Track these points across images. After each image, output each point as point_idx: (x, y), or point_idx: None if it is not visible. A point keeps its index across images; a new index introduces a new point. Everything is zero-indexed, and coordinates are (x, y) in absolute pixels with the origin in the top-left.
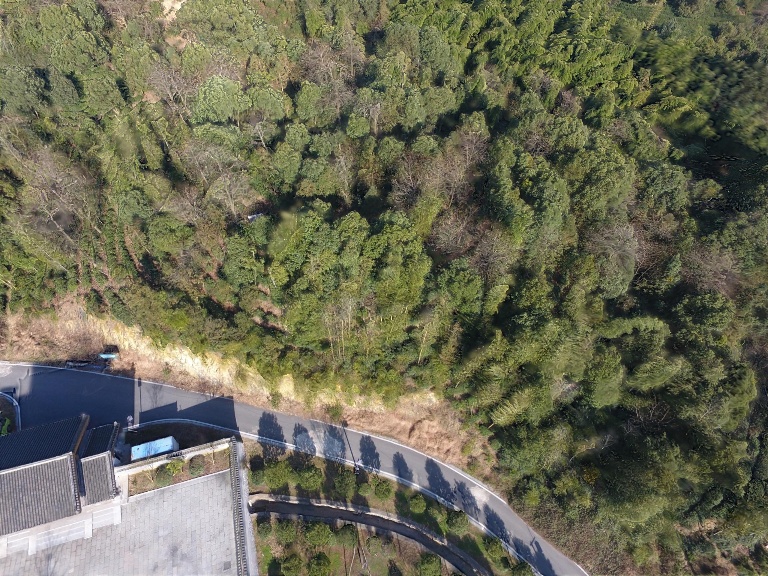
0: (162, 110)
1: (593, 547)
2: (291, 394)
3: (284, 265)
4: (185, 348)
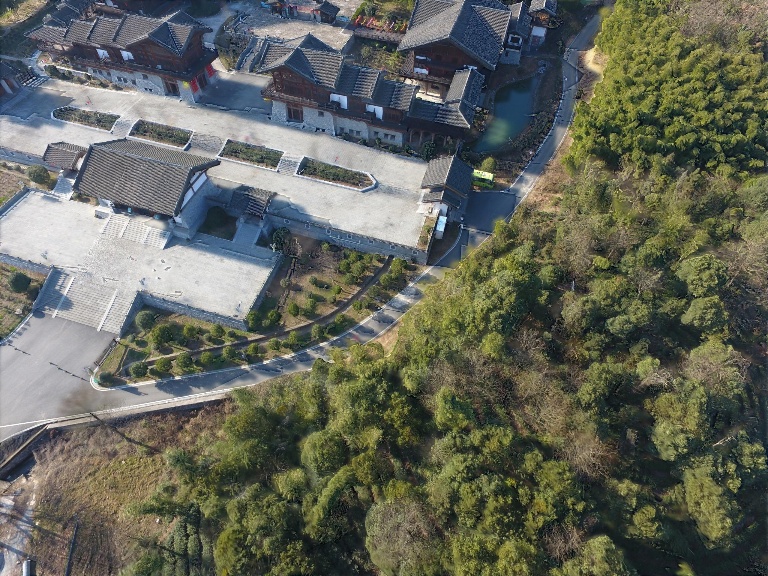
0: None
1: (254, 393)
2: None
3: (504, 269)
4: None
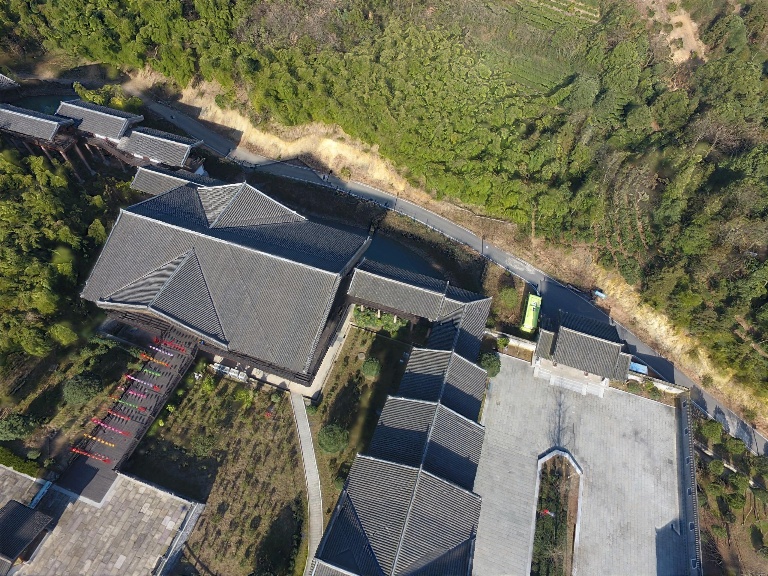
0: (668, 140)
1: None
2: (721, 384)
3: None
4: (661, 316)
